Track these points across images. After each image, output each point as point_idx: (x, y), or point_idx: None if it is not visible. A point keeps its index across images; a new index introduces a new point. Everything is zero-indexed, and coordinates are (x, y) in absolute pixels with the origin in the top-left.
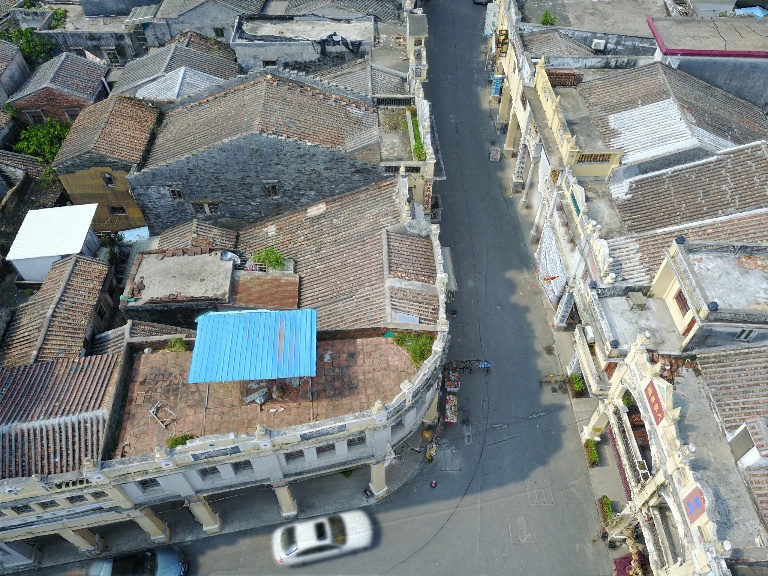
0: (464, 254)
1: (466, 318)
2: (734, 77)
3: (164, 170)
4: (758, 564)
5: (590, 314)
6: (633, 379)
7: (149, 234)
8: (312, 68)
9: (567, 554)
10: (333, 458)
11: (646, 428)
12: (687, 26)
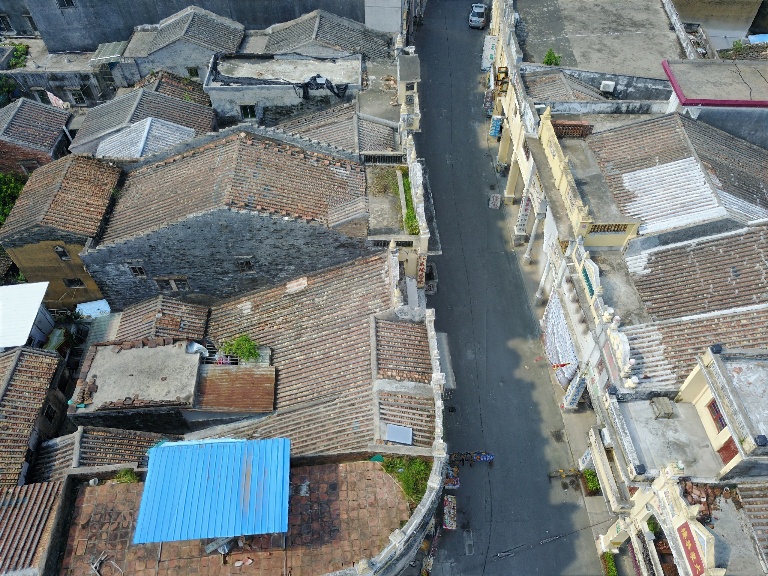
0: (462, 319)
1: (465, 397)
2: (760, 128)
3: (122, 247)
4: None
5: (609, 424)
6: (663, 512)
7: (110, 310)
8: (294, 112)
9: None
10: None
11: (680, 575)
12: (707, 70)
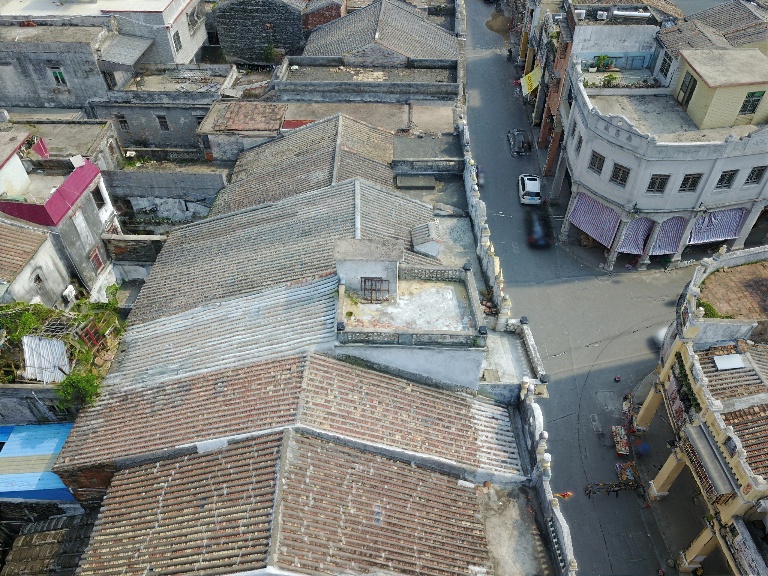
0: None
1: (630, 571)
2: None
3: None
4: None
5: None
6: None
7: None
8: None
9: None
10: None
11: None
12: None
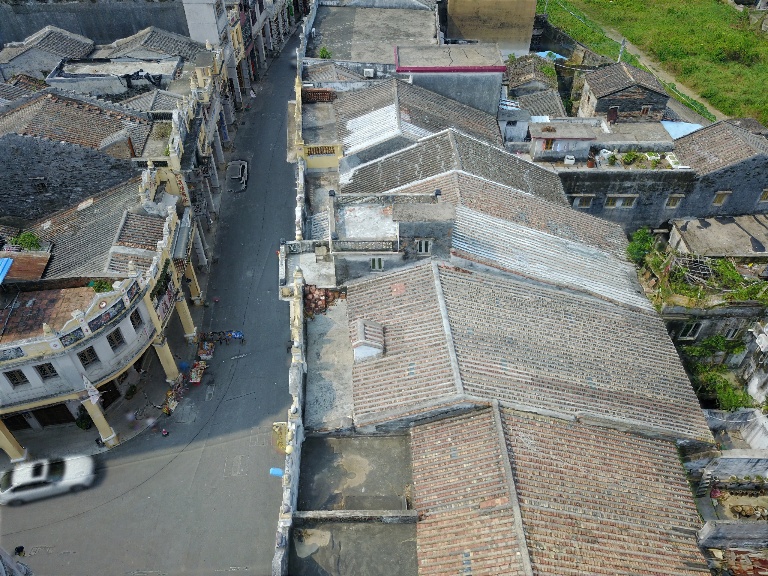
0: (250, 251)
1: (236, 301)
2: (462, 90)
3: None
4: (342, 435)
5: None
6: None
7: None
8: (123, 100)
9: (272, 484)
10: (31, 391)
11: None
12: (425, 51)
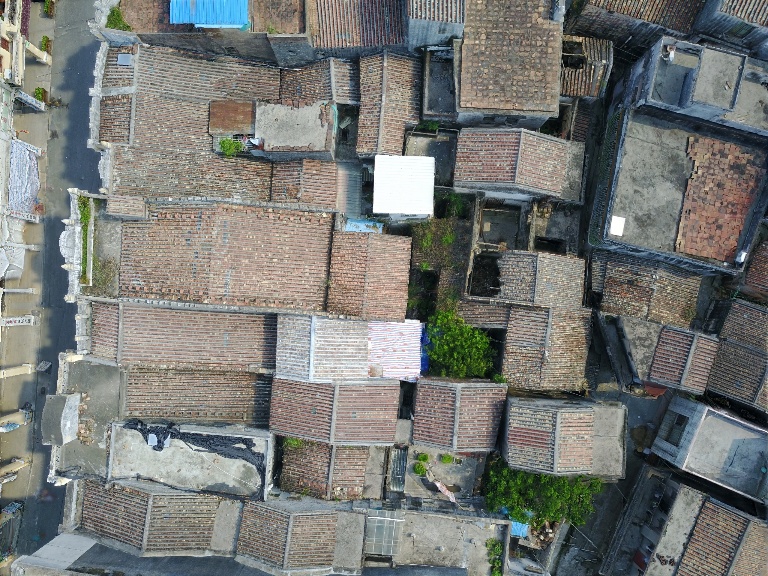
0: None
1: None
2: None
3: None
4: None
5: None
6: None
7: None
8: None
9: None
10: None
11: None
12: None
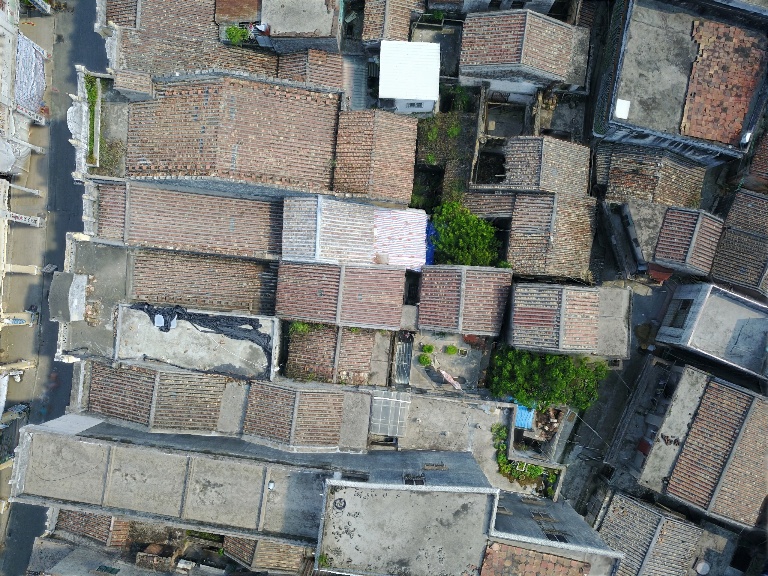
0: None
1: None
2: None
3: None
4: None
5: None
6: None
7: None
8: None
9: None
10: None
11: None
12: None
